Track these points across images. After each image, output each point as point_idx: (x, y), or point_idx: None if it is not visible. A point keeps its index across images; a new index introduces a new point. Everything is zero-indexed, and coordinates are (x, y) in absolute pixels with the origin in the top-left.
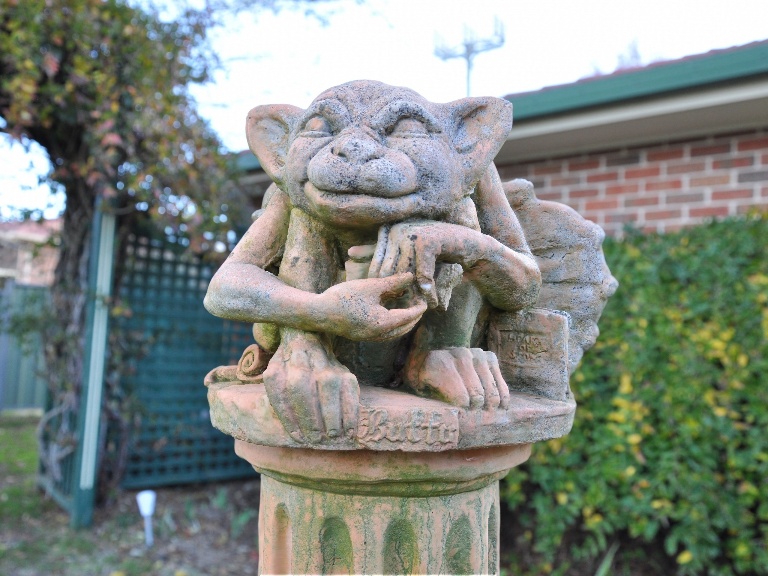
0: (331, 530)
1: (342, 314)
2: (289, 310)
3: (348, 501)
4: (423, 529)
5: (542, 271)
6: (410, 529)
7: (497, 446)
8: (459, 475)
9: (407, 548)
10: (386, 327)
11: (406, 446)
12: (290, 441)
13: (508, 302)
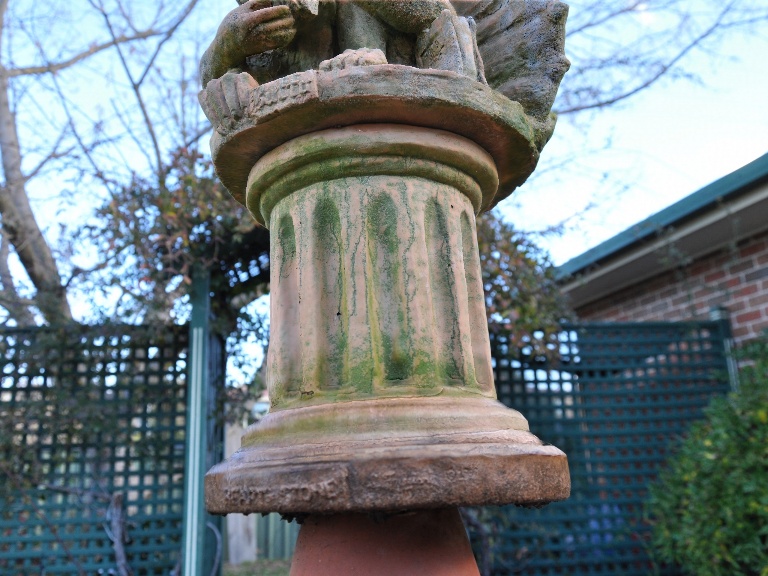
0: (289, 230)
1: (226, 28)
2: (212, 51)
3: (291, 198)
4: (342, 202)
5: (494, 24)
6: (335, 207)
7: (365, 100)
8: (353, 143)
9: (338, 226)
10: (249, 22)
11: (279, 105)
12: (221, 139)
13: (399, 16)
